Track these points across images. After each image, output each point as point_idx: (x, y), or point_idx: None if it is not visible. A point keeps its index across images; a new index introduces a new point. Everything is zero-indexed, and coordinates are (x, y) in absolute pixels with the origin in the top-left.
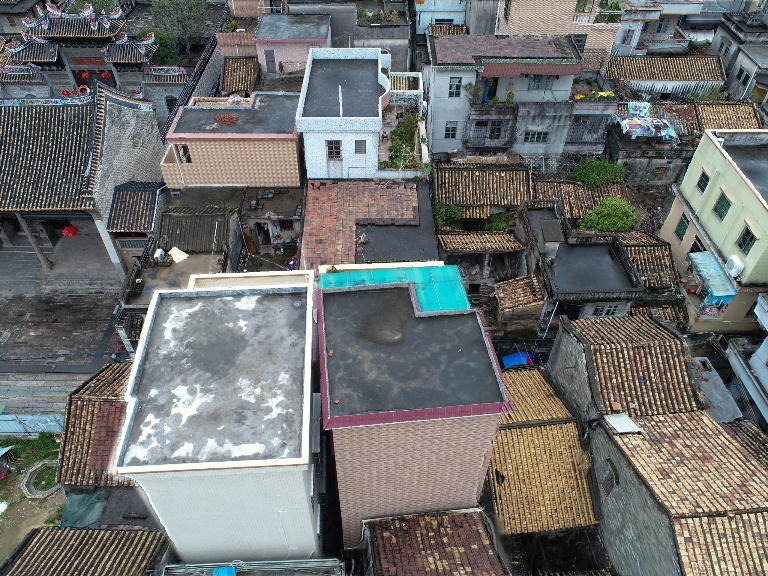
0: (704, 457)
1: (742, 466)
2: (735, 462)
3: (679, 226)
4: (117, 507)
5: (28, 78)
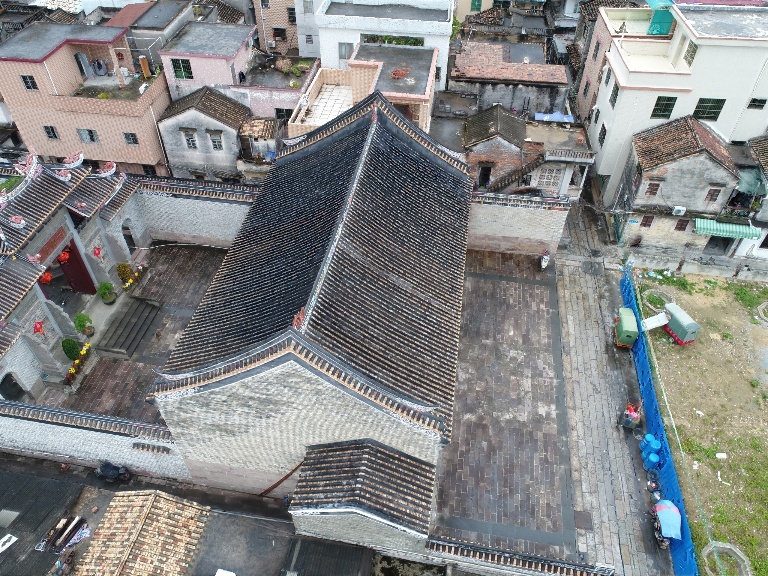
0: None
1: None
2: None
3: (473, 5)
4: (743, 160)
5: (2, 346)
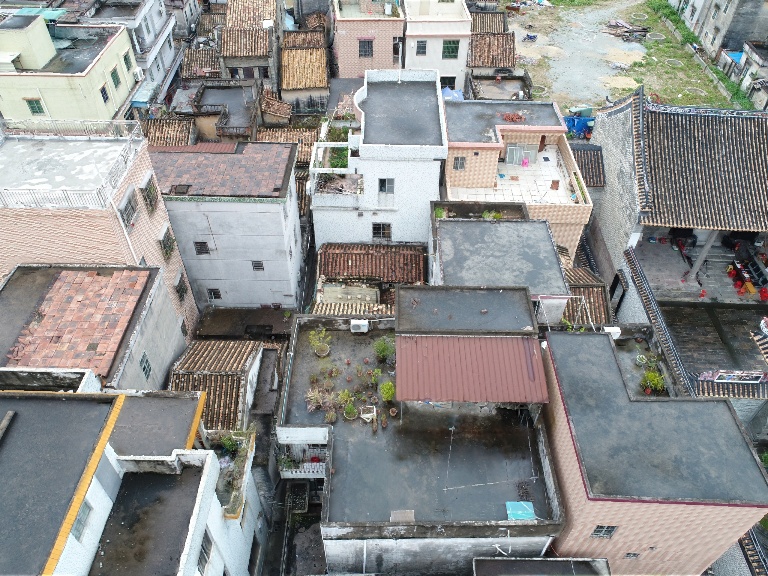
0: (246, 7)
1: (236, 2)
2: (237, 4)
3: None
4: None
5: None
